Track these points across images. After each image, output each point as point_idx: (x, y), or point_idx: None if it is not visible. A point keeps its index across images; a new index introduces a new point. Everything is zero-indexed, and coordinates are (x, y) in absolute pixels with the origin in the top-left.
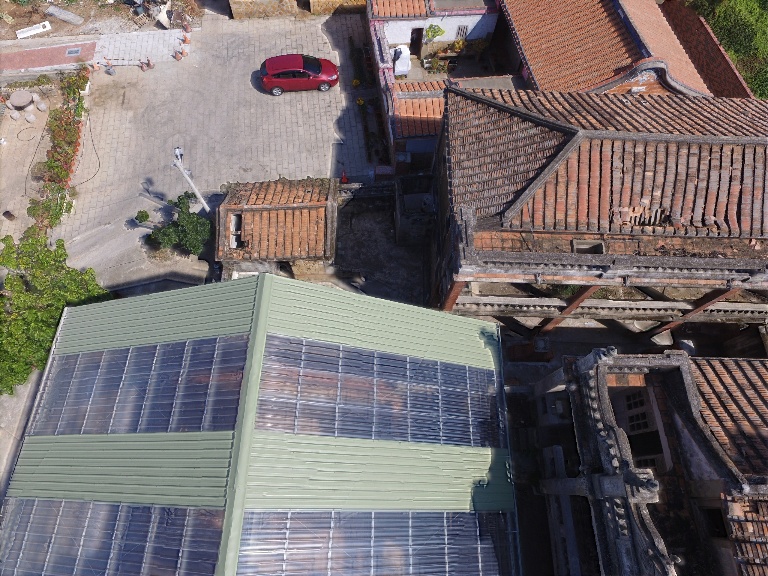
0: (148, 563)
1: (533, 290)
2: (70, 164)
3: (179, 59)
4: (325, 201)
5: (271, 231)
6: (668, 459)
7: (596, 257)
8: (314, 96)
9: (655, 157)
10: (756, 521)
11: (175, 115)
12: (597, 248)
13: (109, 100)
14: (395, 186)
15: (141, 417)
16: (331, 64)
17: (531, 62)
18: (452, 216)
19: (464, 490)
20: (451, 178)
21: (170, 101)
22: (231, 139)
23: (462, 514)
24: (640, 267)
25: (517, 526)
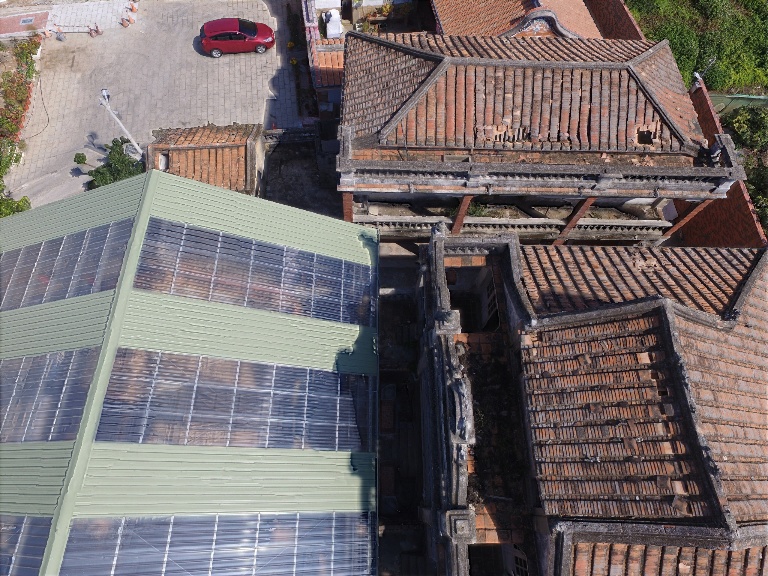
0: (41, 394)
1: (428, 213)
2: (20, 120)
3: (126, 26)
4: (245, 140)
5: (196, 168)
6: None
7: (455, 164)
8: (252, 58)
9: (514, 81)
10: (540, 347)
11: (121, 76)
12: None
13: (59, 63)
14: None
15: (46, 291)
16: (267, 28)
17: (442, 18)
18: None
19: (330, 355)
20: (343, 107)
21: (116, 63)
22: (172, 96)
23: (325, 372)
24: (499, 175)
25: (377, 387)
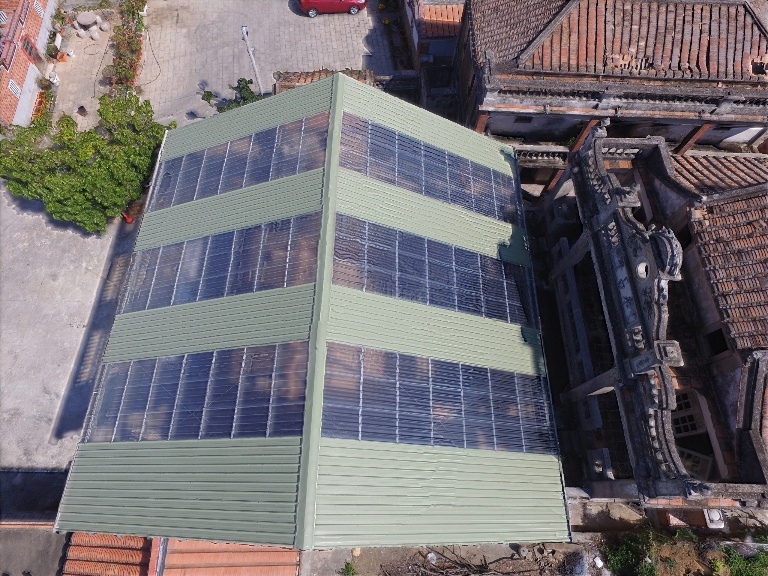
0: (264, 255)
1: None
2: (135, 68)
3: None
4: (364, 80)
5: None
6: (650, 215)
7: (593, 84)
8: (345, 18)
9: (640, 14)
10: (712, 218)
11: (224, 32)
12: None
13: (165, 20)
14: (421, 77)
15: (245, 178)
16: None
17: None
18: (476, 67)
19: (492, 245)
20: (474, 41)
21: (218, 21)
22: (274, 51)
23: (491, 259)
24: (628, 98)
25: (533, 276)
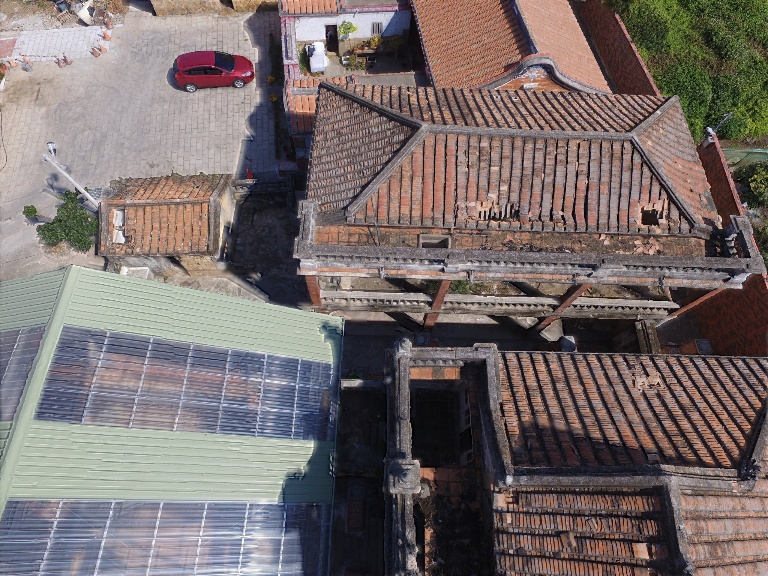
0: None
1: (406, 285)
2: None
3: (97, 56)
4: (208, 196)
5: (154, 226)
6: None
7: (431, 251)
8: (229, 93)
9: (501, 152)
10: (516, 512)
11: (87, 111)
12: (445, 243)
13: (23, 96)
14: None
15: None
16: (246, 61)
17: (431, 58)
18: None
19: (276, 482)
20: (310, 173)
21: (84, 97)
22: (141, 135)
23: (268, 506)
24: (481, 261)
25: (331, 518)
